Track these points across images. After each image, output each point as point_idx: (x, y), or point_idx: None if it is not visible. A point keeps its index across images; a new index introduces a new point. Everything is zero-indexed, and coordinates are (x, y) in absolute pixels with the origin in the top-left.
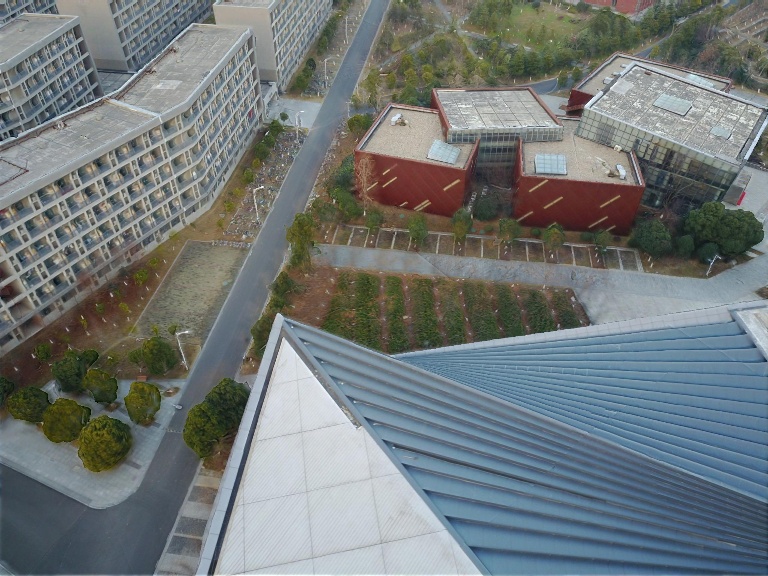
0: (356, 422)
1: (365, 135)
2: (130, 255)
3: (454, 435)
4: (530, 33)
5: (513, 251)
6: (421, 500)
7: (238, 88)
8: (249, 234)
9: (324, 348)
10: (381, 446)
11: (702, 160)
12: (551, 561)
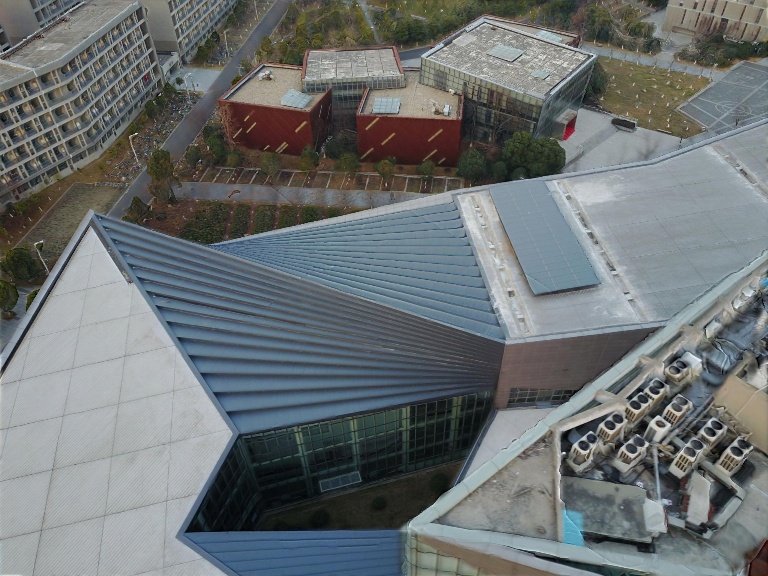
0: (130, 281)
1: (231, 88)
2: (18, 193)
3: (203, 286)
4: (425, 4)
5: (355, 182)
6: (162, 328)
7: (127, 53)
8: (129, 176)
9: (120, 232)
10: (143, 295)
11: (515, 97)
12: (250, 364)
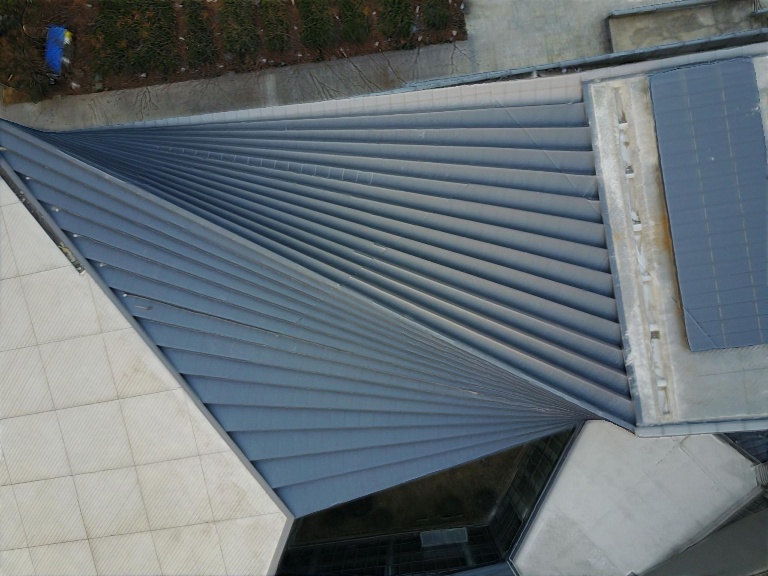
0: (79, 263)
1: None
2: None
3: (192, 280)
4: None
5: None
6: (155, 357)
7: None
8: None
9: (25, 158)
10: (109, 296)
11: None
12: (288, 411)
